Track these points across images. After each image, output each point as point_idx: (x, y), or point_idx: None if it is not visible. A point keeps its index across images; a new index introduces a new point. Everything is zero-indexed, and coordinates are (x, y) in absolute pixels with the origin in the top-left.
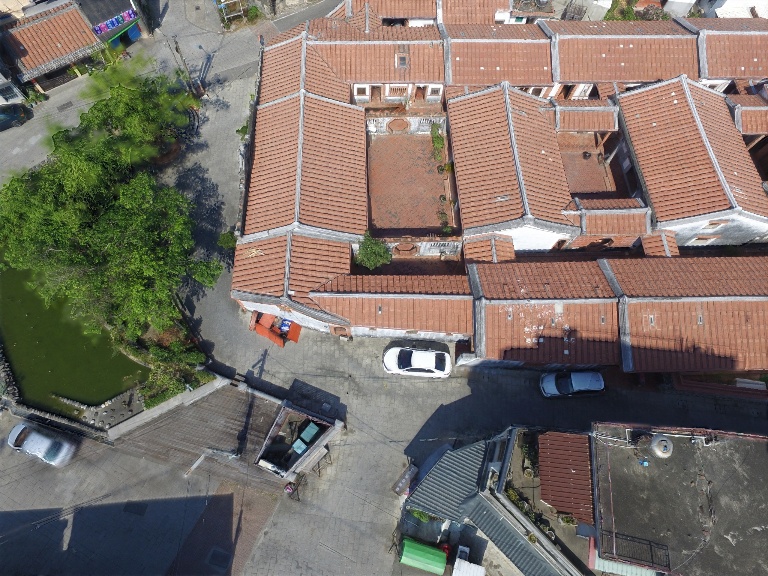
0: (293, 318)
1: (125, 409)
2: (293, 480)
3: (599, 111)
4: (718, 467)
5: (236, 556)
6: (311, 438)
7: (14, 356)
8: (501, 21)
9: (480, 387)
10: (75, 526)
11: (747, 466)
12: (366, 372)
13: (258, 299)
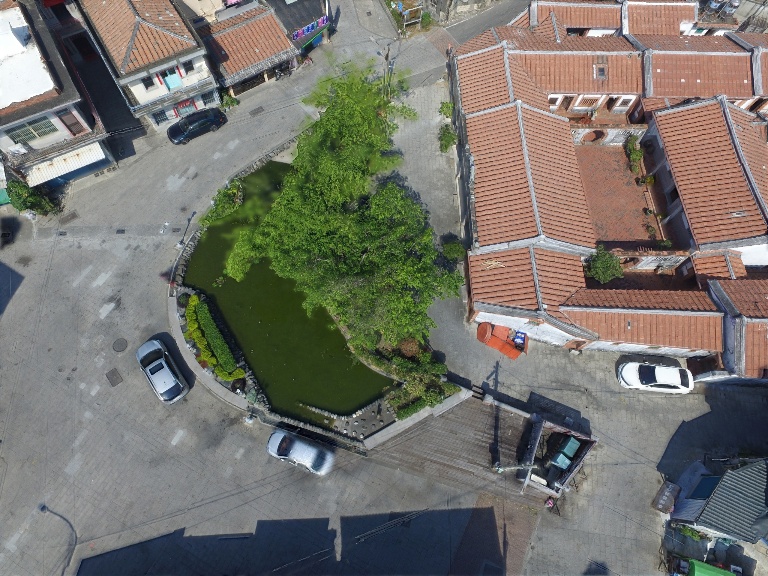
0: (530, 331)
1: (375, 419)
2: (560, 495)
3: None
4: None
5: (508, 570)
6: (574, 453)
7: (254, 363)
8: (681, 32)
9: (719, 404)
10: (344, 537)
11: None
12: (602, 386)
13: (508, 312)
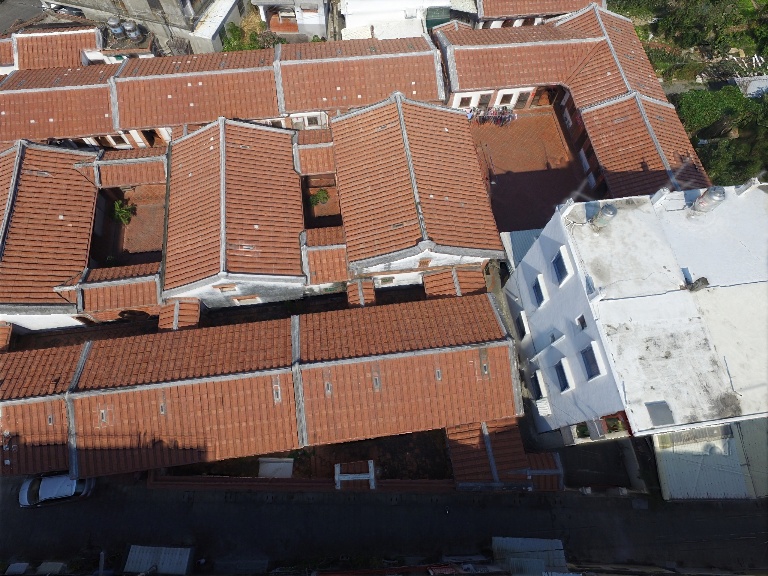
0: None
1: None
2: None
3: (146, 162)
4: None
5: None
6: None
7: None
8: (100, 60)
9: None
10: None
11: None
12: None
13: None
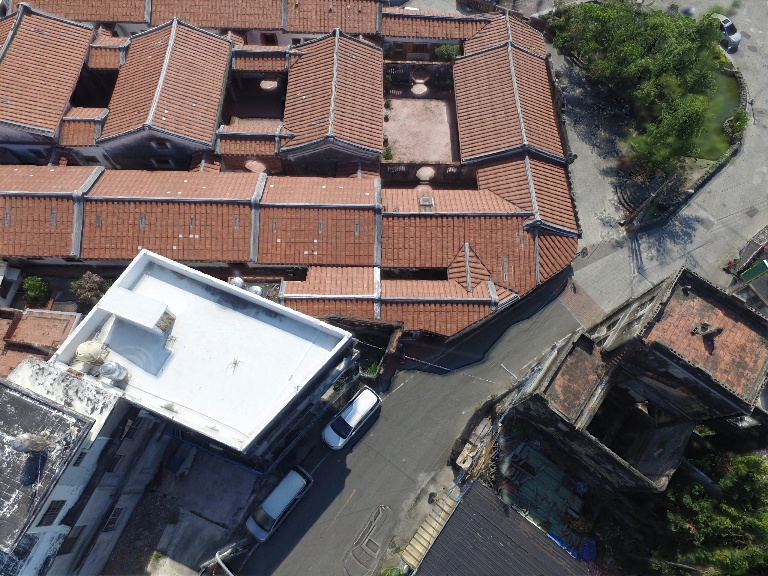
0: None
1: None
2: None
3: None
4: None
5: None
6: None
7: None
8: None
9: None
10: None
11: None
12: None
13: None
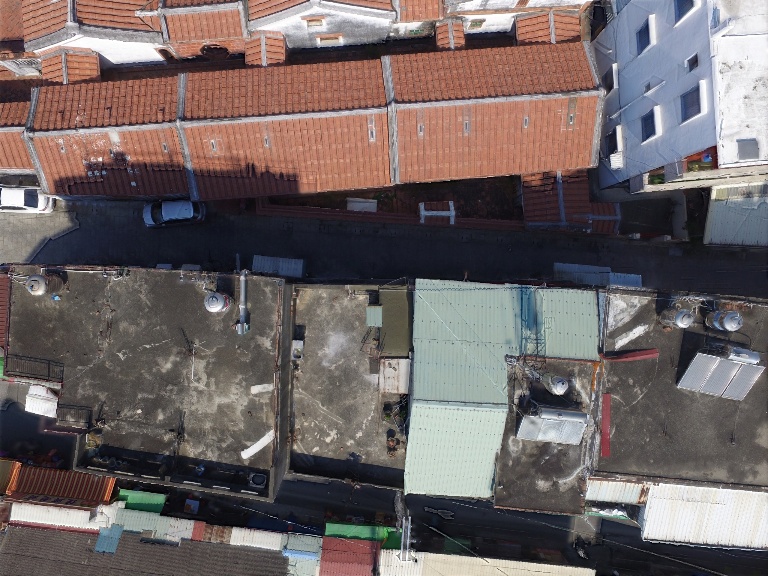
0: None
1: None
2: None
3: None
4: (124, 297)
5: None
6: None
7: None
8: None
9: (88, 220)
10: None
11: (152, 295)
12: None
13: None
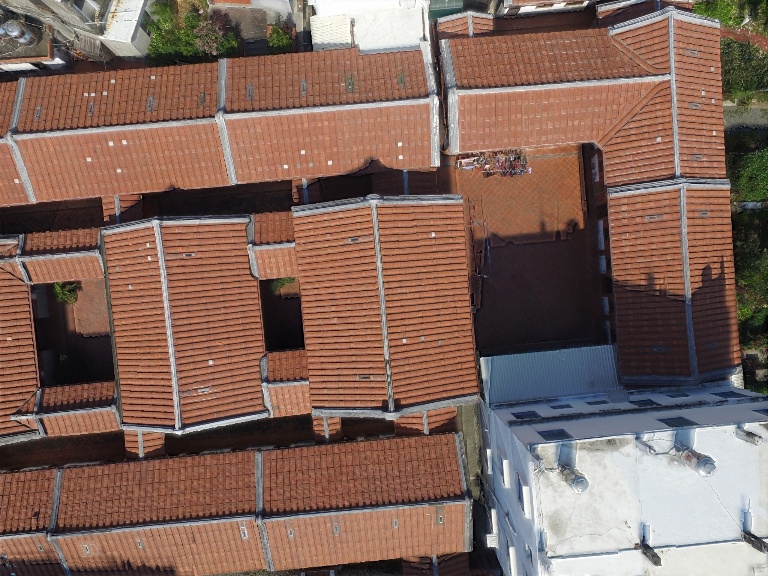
0: None
1: None
2: None
3: (78, 257)
4: None
5: None
6: None
7: None
8: None
9: None
10: None
11: None
12: None
13: None
